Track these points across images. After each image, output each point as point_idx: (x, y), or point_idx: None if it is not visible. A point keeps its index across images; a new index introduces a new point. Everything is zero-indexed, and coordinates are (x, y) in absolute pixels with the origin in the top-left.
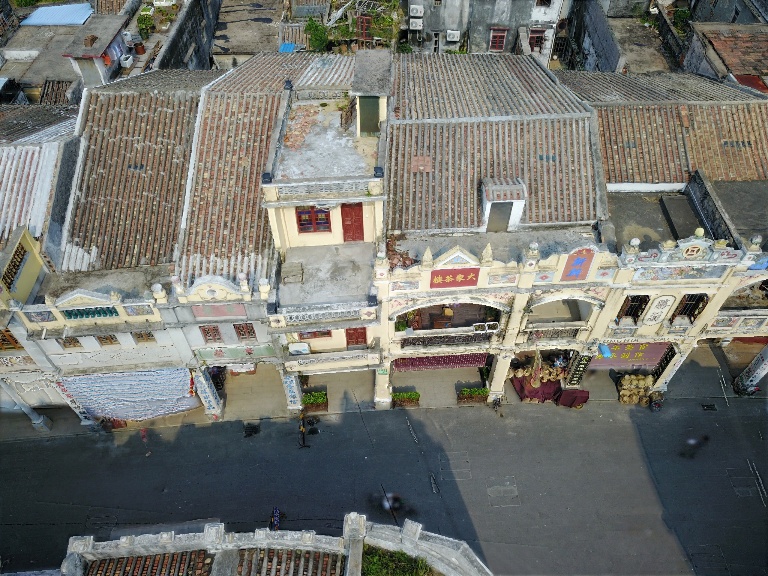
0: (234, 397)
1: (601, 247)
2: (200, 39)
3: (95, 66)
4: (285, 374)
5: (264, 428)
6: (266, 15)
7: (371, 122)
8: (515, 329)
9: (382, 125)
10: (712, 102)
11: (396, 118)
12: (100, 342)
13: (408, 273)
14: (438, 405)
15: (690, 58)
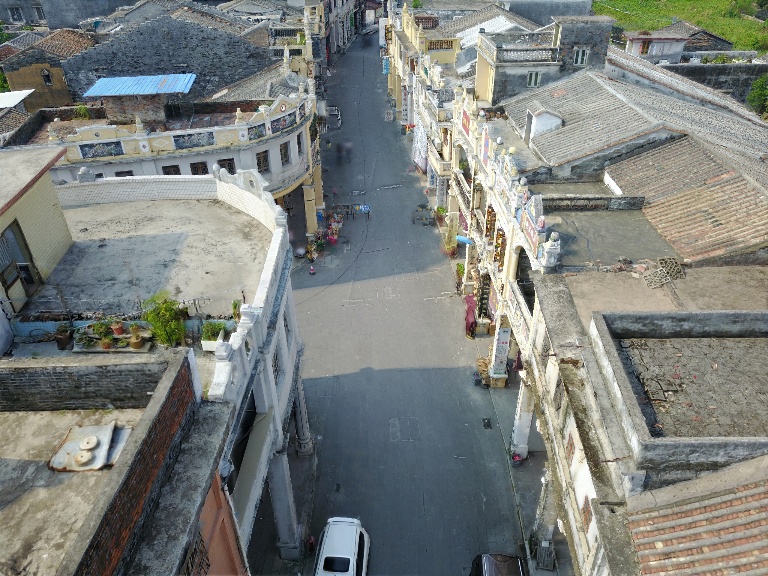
0: None
1: (492, 134)
2: None
3: (632, 48)
4: None
5: (425, 209)
6: None
7: None
8: None
9: None
10: (759, 186)
11: (596, 74)
12: None
13: None
14: (454, 267)
15: None
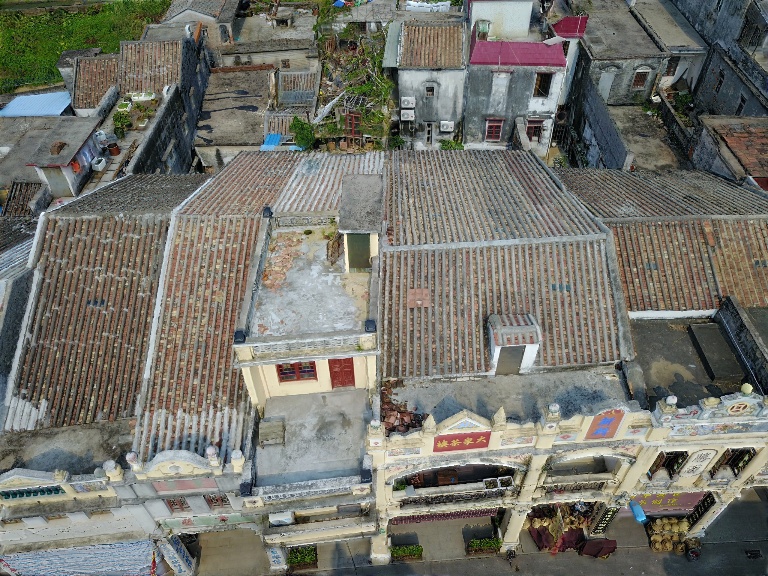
0: (210, 551)
1: (632, 406)
2: (181, 133)
3: (62, 174)
4: (265, 546)
5: None
6: (252, 103)
7: (361, 258)
8: (532, 486)
9: (373, 262)
10: (738, 216)
11: (389, 243)
12: (46, 517)
13: (407, 439)
14: (444, 557)
15: (700, 153)
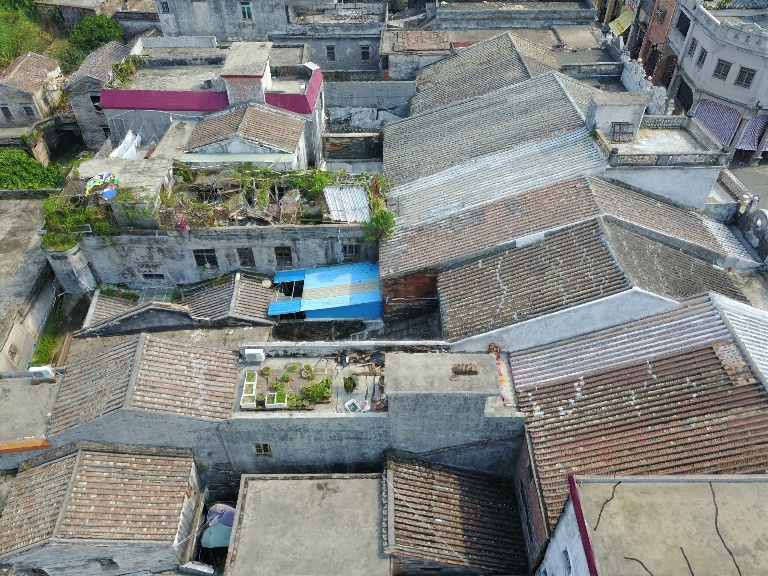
0: None
1: None
2: None
3: None
4: None
5: None
6: None
7: None
8: None
9: None
10: None
11: None
12: None
13: None
14: None
15: (396, 69)
